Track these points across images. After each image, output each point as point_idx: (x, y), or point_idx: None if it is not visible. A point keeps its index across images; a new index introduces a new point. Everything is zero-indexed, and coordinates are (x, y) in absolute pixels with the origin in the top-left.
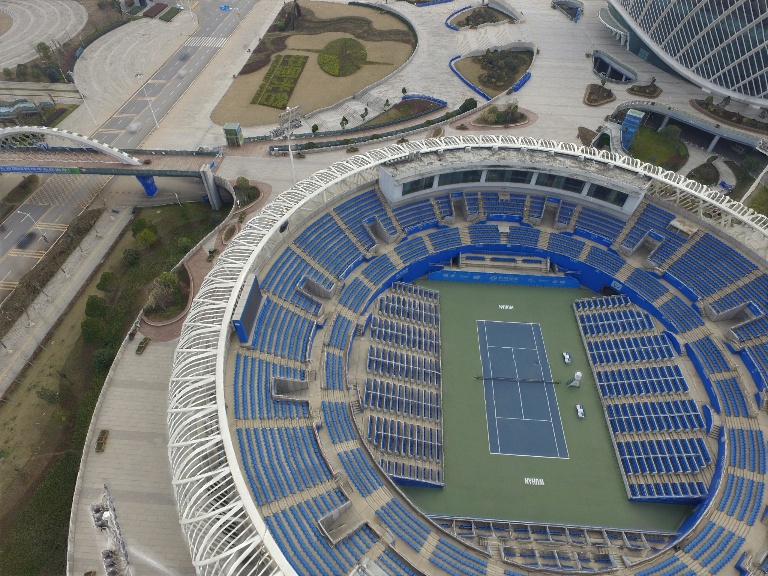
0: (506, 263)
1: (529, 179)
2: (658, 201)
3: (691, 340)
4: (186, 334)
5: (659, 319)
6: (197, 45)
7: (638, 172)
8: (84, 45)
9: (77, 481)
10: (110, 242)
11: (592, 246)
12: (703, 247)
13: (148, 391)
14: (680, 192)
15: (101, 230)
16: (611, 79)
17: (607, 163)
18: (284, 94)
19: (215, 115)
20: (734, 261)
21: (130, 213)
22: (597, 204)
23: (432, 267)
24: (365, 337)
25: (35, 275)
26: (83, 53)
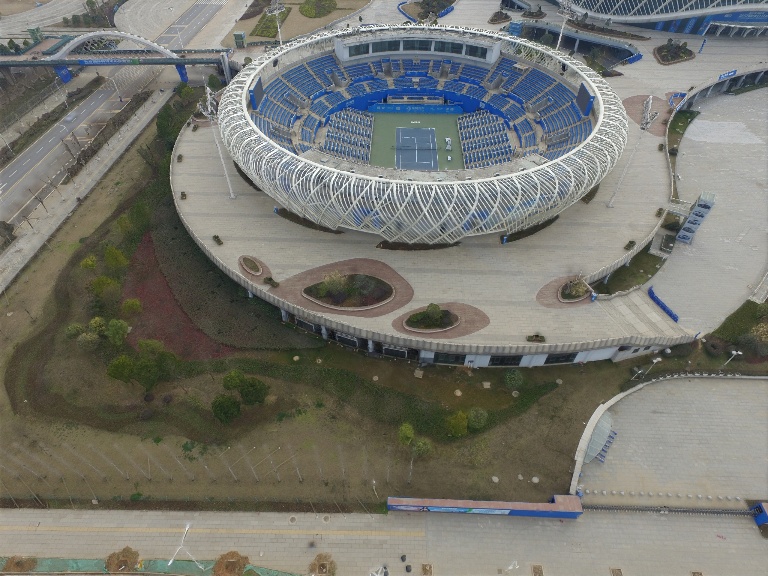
0: (417, 100)
1: (430, 47)
2: (509, 56)
3: (517, 123)
4: (224, 95)
5: (503, 117)
6: (205, 4)
7: (494, 36)
8: (118, 4)
9: (170, 167)
10: (161, 105)
11: (469, 86)
12: (530, 76)
13: (201, 143)
14: (524, 51)
15: (154, 100)
16: (511, 9)
17: (476, 33)
18: (274, 29)
19: (224, 43)
20: (545, 80)
21: (172, 92)
22: (472, 60)
23: (370, 103)
24: (325, 127)
25: (117, 117)
26: (119, 10)
